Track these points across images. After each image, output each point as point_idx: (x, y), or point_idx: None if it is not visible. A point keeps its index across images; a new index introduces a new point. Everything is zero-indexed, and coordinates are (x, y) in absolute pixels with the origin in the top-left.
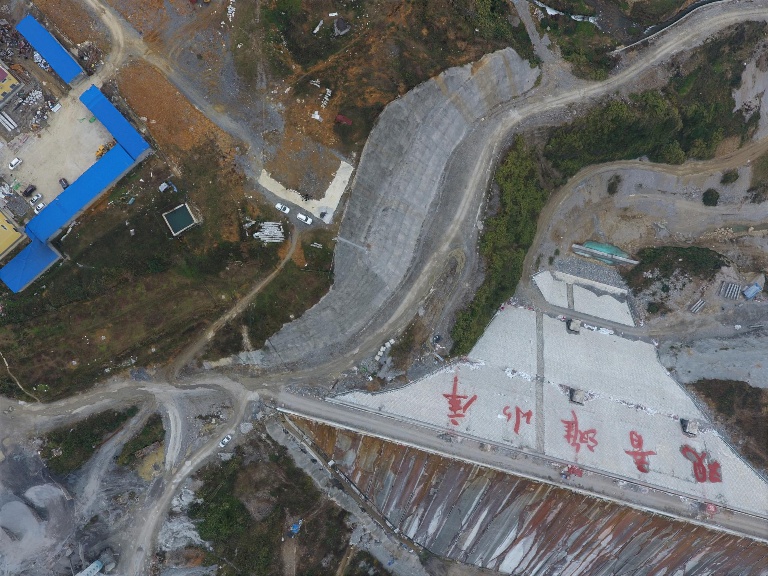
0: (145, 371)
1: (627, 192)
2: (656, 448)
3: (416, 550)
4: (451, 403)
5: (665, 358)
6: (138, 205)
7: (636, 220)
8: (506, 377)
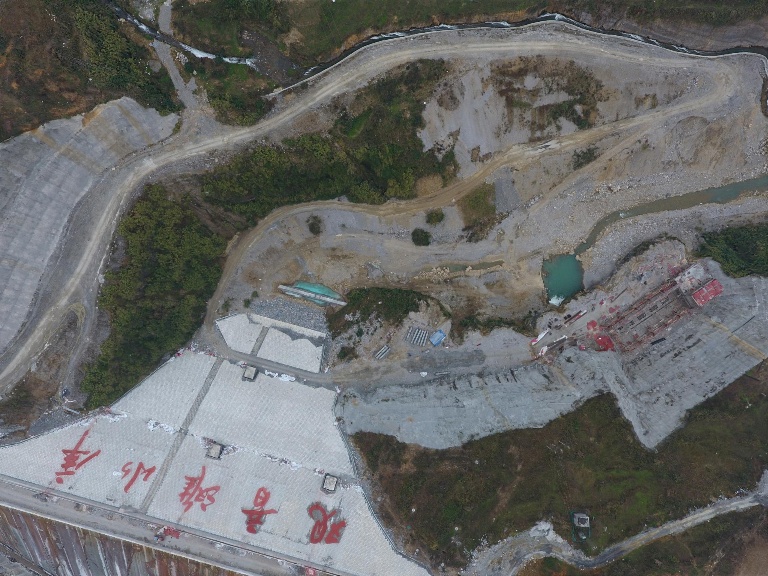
0: None
1: (333, 232)
2: (280, 506)
3: None
4: (66, 459)
5: (337, 407)
6: None
7: (346, 260)
8: (146, 430)
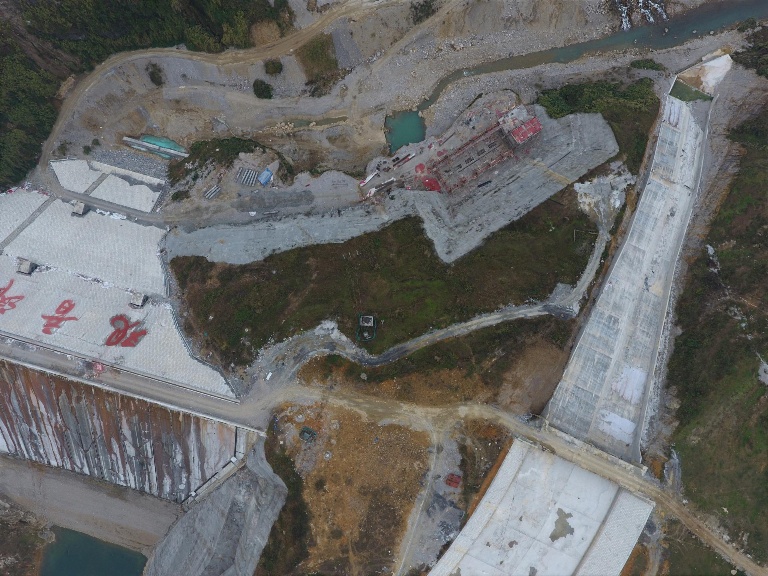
0: None
1: (176, 83)
2: (83, 315)
3: None
4: None
5: None
6: None
7: (190, 113)
8: None
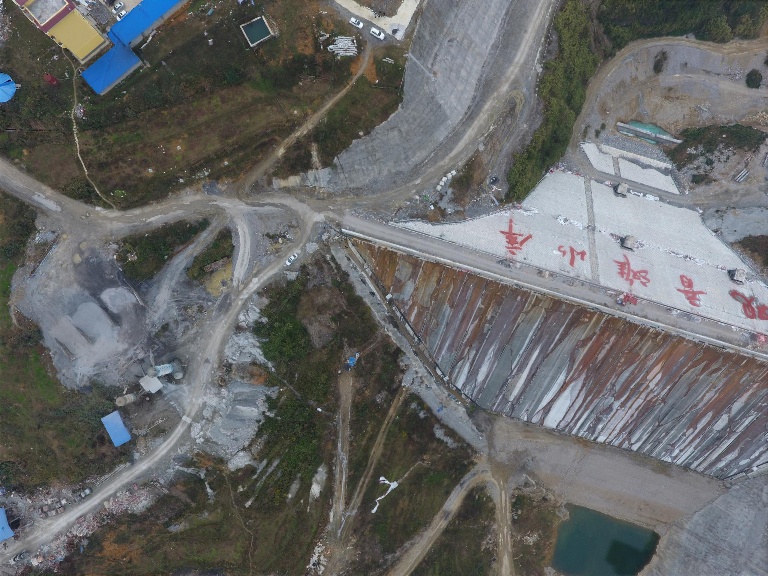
0: (217, 186)
1: (672, 72)
2: (706, 289)
3: (463, 402)
4: (508, 238)
5: (710, 221)
6: (216, 17)
7: (680, 101)
8: (559, 224)
